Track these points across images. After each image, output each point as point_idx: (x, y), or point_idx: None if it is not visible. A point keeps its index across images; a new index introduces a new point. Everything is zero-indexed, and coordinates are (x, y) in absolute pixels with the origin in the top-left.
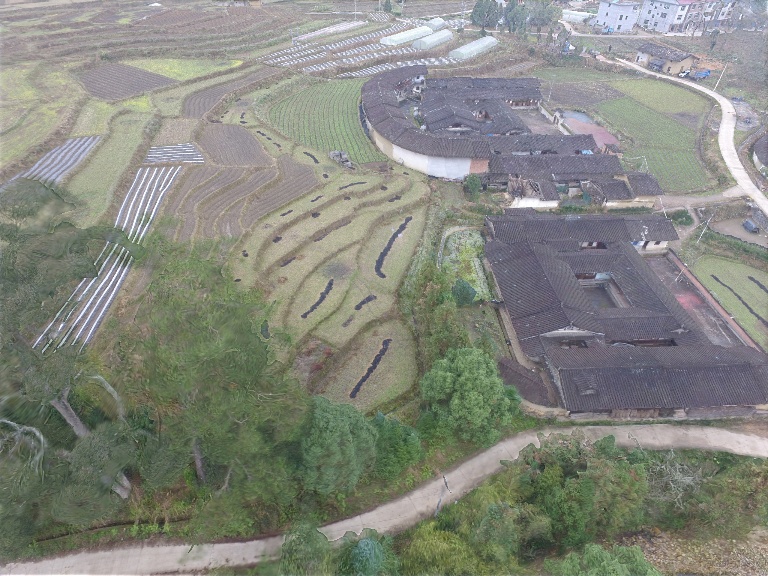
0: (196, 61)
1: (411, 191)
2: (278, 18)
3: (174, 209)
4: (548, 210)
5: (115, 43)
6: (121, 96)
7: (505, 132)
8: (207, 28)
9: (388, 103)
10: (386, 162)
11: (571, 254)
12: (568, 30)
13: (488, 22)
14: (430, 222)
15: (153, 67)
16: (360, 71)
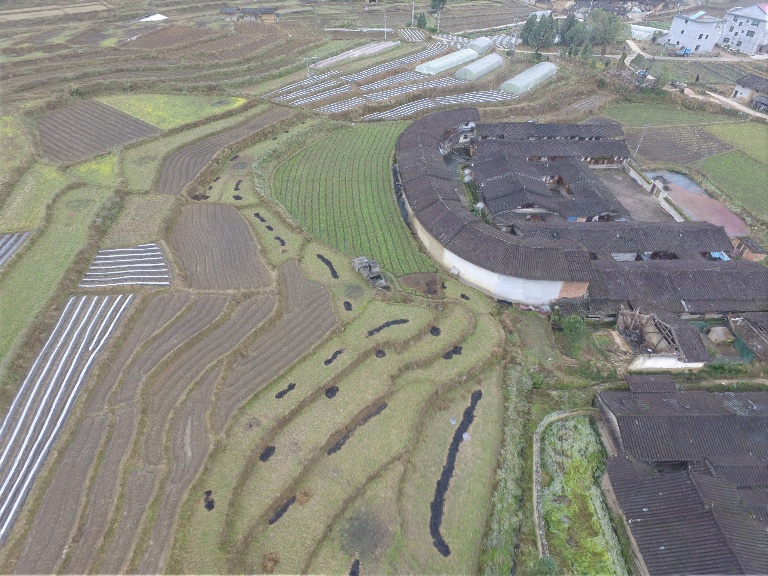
0: (188, 98)
1: (476, 336)
2: (293, 37)
3: (104, 395)
4: (686, 371)
5: (92, 73)
6: (80, 155)
7: (594, 215)
8: (206, 52)
9: (434, 174)
10: (435, 274)
11: (764, 499)
12: (634, 50)
13: (544, 43)
14: (512, 406)
15: (133, 107)
16: (391, 110)
